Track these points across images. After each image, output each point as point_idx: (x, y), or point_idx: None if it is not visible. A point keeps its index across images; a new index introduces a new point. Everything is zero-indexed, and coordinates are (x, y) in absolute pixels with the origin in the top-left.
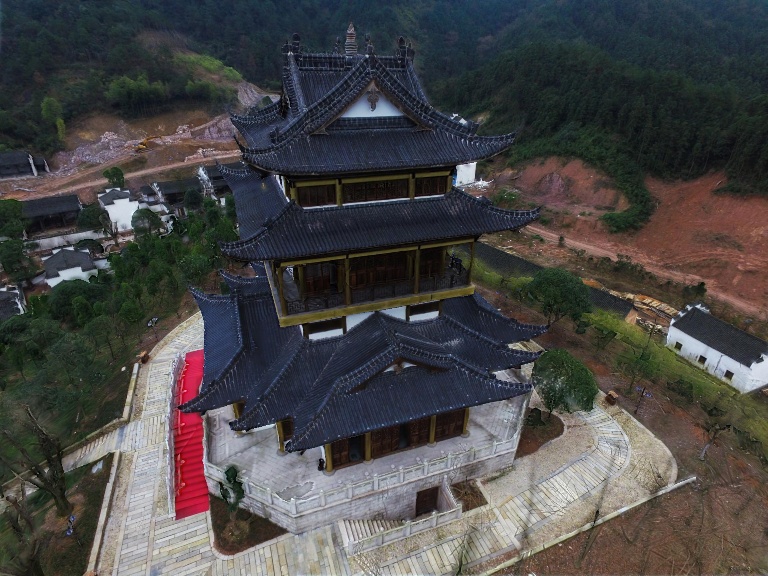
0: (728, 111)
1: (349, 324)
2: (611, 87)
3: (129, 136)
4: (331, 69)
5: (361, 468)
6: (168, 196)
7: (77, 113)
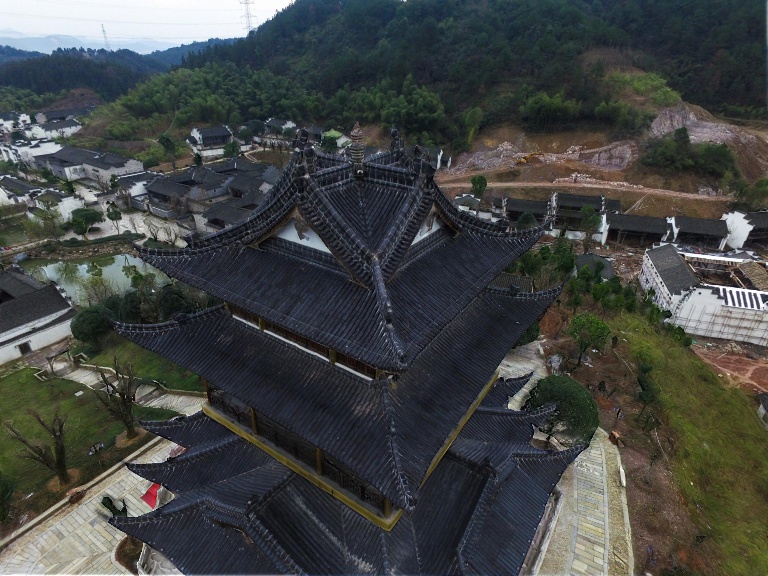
0: None
1: None
2: None
3: (522, 148)
4: None
5: None
6: (511, 213)
7: (492, 122)
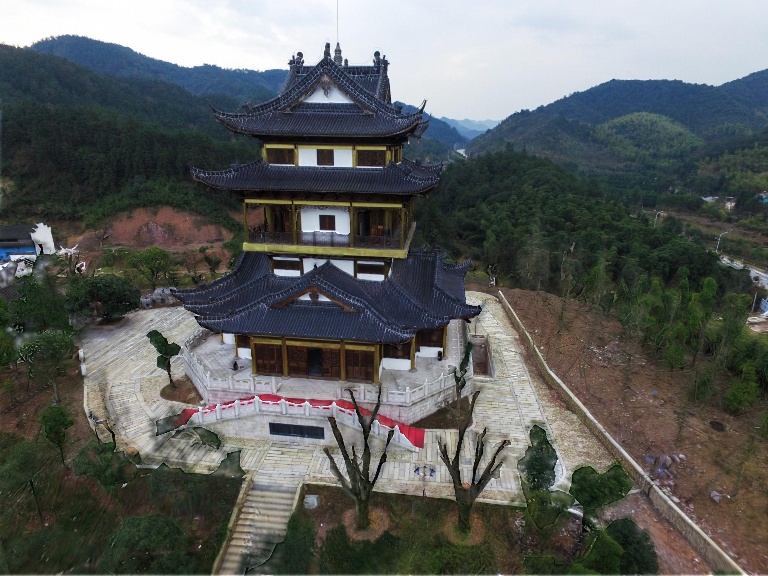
0: (253, 157)
1: None
2: (156, 143)
3: None
4: None
5: (449, 348)
6: None
7: None
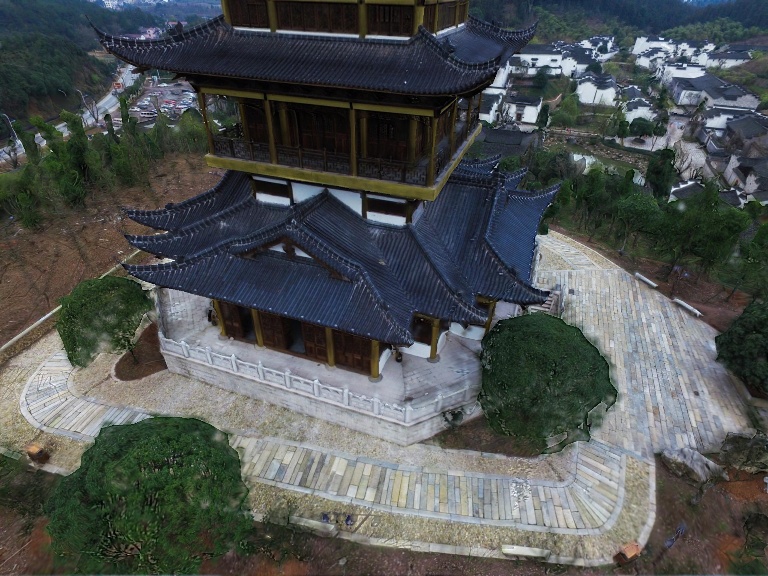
0: None
1: None
2: None
3: None
4: None
5: None
6: None
7: None
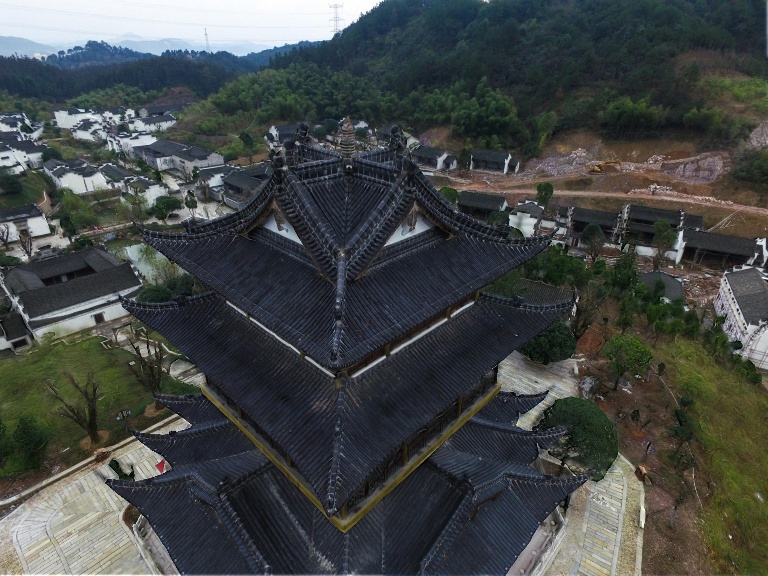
0: None
1: None
2: None
3: (597, 156)
4: None
5: None
6: (576, 223)
7: (567, 127)
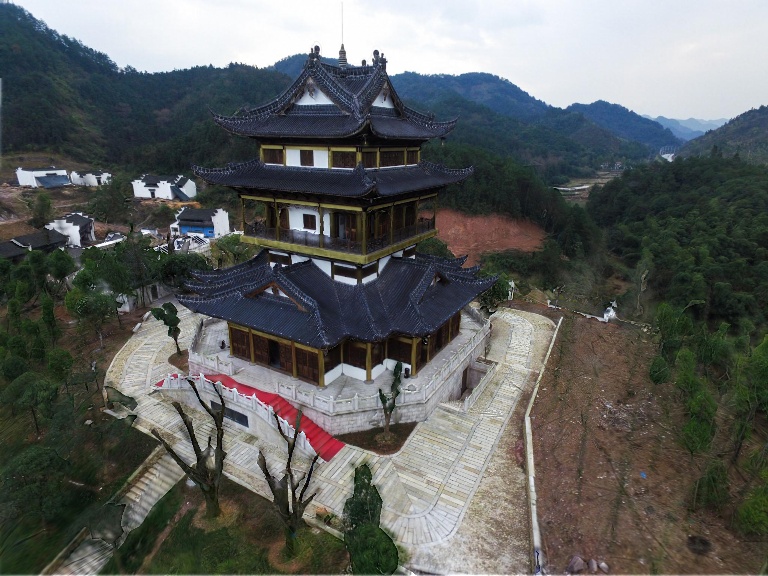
0: None
1: (379, 268)
2: None
3: None
4: (334, 75)
5: (429, 367)
6: None
7: None
